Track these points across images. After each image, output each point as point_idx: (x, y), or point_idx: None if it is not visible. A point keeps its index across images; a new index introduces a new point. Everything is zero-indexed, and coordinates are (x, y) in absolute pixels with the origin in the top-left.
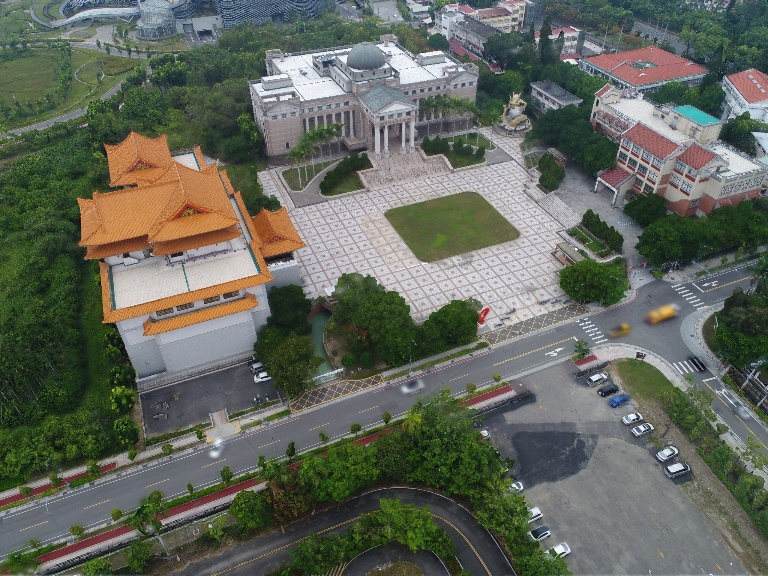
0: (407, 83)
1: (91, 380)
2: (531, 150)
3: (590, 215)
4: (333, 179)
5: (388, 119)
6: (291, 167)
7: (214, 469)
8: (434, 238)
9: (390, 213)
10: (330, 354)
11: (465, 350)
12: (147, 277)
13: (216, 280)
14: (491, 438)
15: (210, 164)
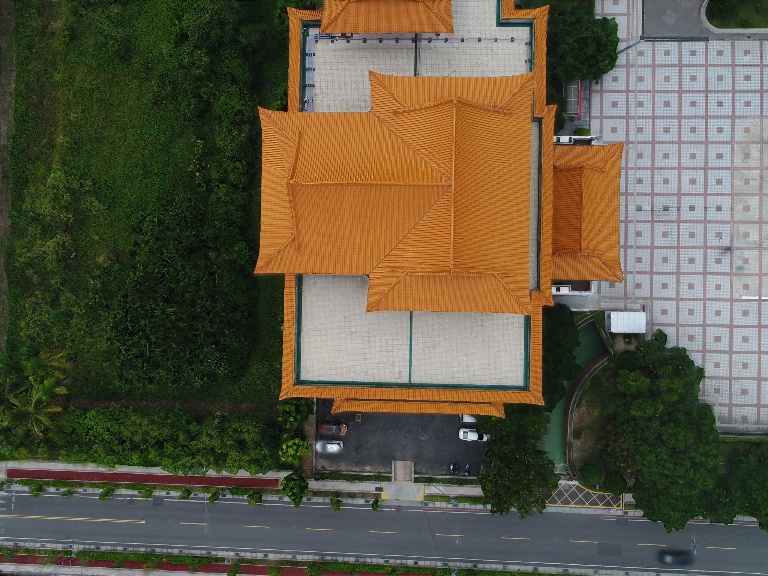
0: None
1: (260, 337)
2: None
3: None
4: None
5: None
6: None
7: (382, 540)
8: None
9: None
10: (571, 436)
11: None
12: (353, 310)
13: (455, 365)
14: None
15: None
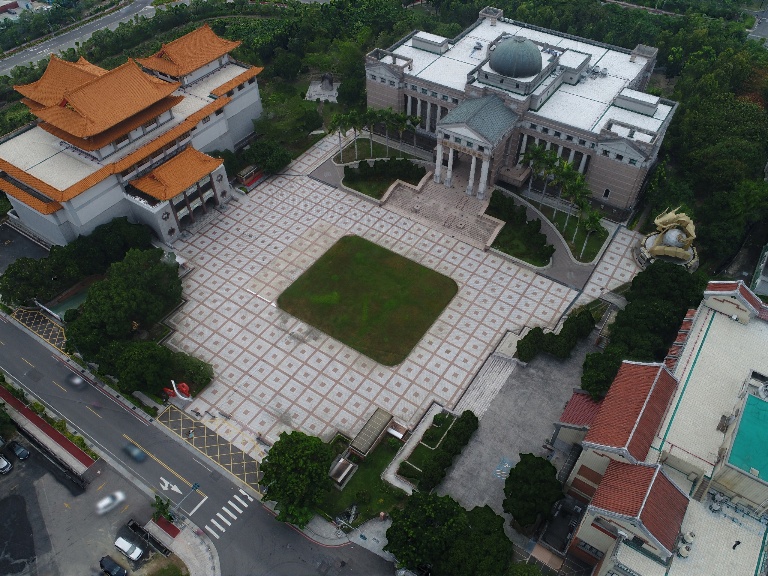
0: (544, 114)
1: None
2: (618, 298)
3: (463, 418)
4: (362, 171)
5: (454, 141)
6: (376, 138)
7: None
8: (327, 292)
9: (349, 239)
10: None
11: (134, 399)
12: (40, 141)
13: (49, 174)
14: (8, 475)
15: (333, 95)
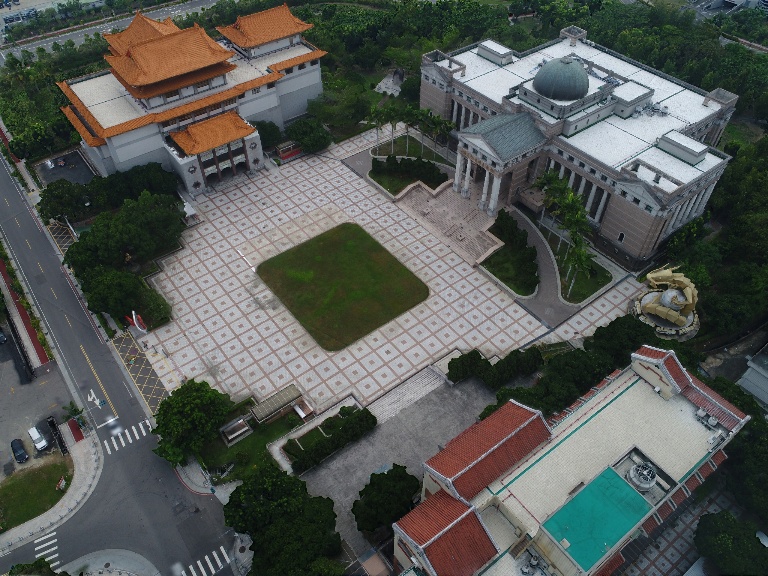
0: (573, 142)
1: None
2: None
3: (359, 414)
4: (388, 165)
5: (472, 152)
6: None
7: (1, 203)
8: (304, 269)
9: (349, 226)
10: None
11: (101, 318)
12: (112, 85)
13: (104, 113)
14: None
15: None
